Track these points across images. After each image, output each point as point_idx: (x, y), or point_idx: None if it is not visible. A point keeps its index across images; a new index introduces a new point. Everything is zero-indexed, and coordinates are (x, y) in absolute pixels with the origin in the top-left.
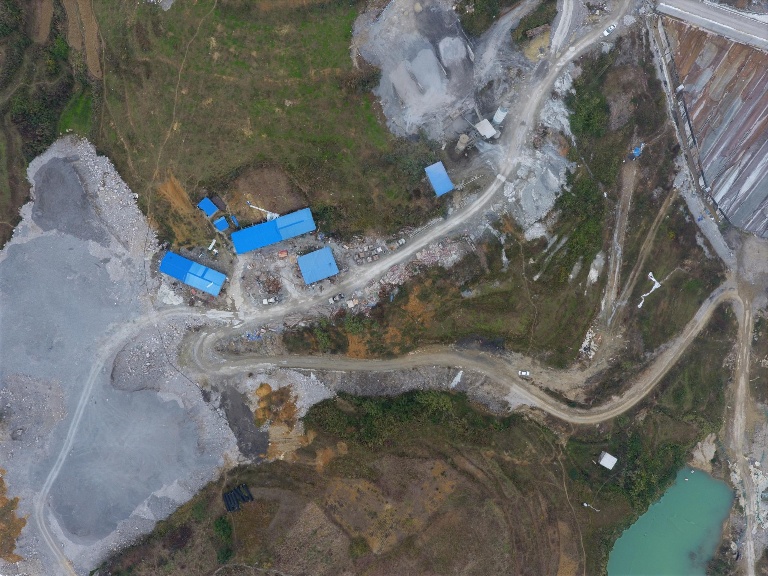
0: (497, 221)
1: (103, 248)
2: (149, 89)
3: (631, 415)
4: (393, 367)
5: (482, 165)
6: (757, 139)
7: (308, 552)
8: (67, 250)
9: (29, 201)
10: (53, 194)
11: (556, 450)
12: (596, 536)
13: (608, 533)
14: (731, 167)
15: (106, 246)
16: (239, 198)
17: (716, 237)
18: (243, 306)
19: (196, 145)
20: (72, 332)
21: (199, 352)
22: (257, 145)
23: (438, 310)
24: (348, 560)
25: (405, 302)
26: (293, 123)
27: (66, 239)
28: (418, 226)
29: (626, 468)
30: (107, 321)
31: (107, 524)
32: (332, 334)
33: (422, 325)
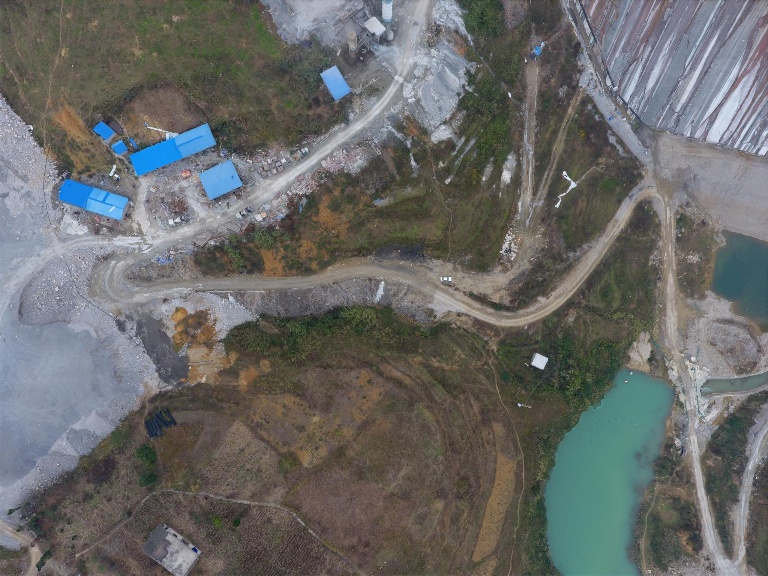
0: (400, 123)
1: (0, 183)
2: (33, 16)
3: (559, 315)
4: (313, 283)
5: (379, 68)
6: (654, 30)
7: (237, 471)
8: None
9: None
10: None
11: (487, 355)
12: (533, 435)
13: (545, 432)
14: (634, 63)
15: (3, 181)
16: (136, 120)
17: (629, 136)
18: (150, 230)
19: (86, 69)
20: None
21: (110, 282)
22: (149, 64)
23: (352, 221)
24: (278, 476)
25: (315, 213)
26: (183, 39)
27: None
28: (320, 134)
29: (559, 368)
30: (10, 257)
31: (25, 461)
32: (245, 252)
33: (338, 238)
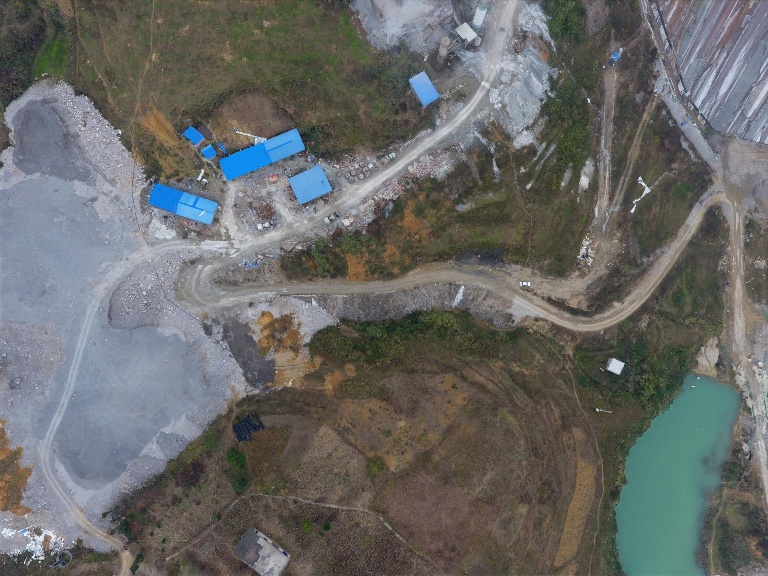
0: (485, 129)
1: (89, 187)
2: (124, 21)
3: (634, 320)
4: (394, 288)
5: (465, 73)
6: (731, 36)
7: (325, 475)
8: (52, 192)
9: (9, 146)
10: (33, 137)
11: (563, 360)
12: (611, 440)
13: (622, 437)
14: (708, 68)
15: (92, 185)
16: (224, 125)
17: (700, 141)
18: (238, 234)
19: (176, 74)
20: (64, 274)
21: (197, 286)
22: (238, 69)
23: (434, 226)
24: (366, 480)
25: (401, 218)
26: (273, 44)
27: (50, 181)
28: (407, 139)
29: (634, 373)
30: (99, 260)
31: (116, 465)
32: (330, 256)
33: (419, 243)
